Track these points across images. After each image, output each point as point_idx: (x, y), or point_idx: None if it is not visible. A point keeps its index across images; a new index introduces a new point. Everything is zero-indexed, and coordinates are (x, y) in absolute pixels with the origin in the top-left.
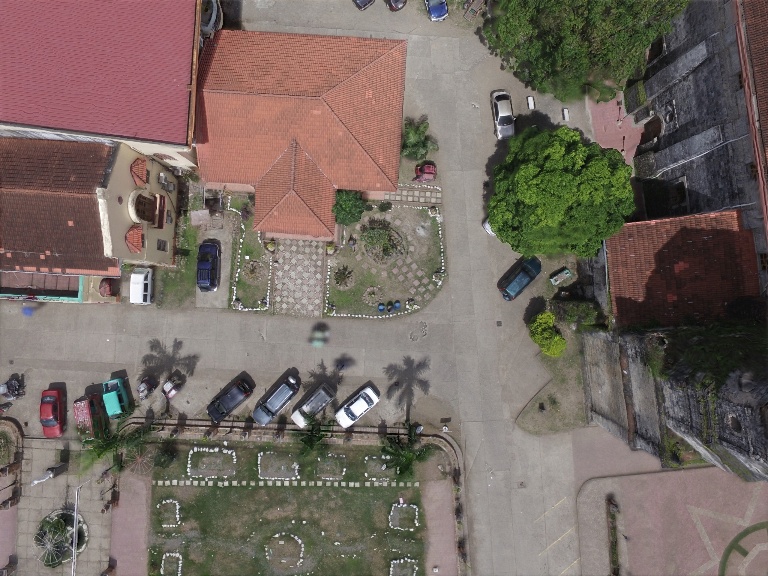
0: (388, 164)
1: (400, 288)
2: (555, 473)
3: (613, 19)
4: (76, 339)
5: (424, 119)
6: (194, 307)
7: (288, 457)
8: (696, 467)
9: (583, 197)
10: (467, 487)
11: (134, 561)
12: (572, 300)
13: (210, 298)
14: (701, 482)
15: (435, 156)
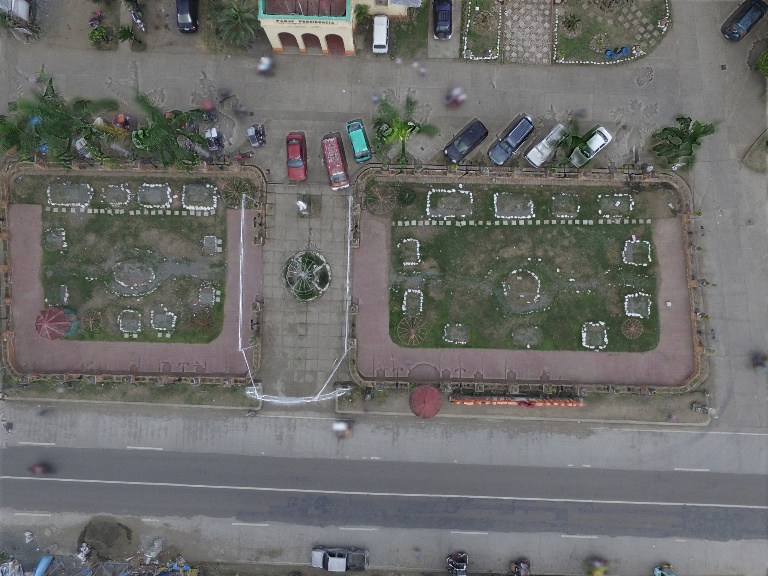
0: None
1: (626, 35)
2: None
3: None
4: (313, 90)
5: None
6: (426, 58)
7: (523, 196)
8: None
9: None
10: (697, 225)
11: (376, 299)
12: None
13: (442, 49)
14: None
15: None
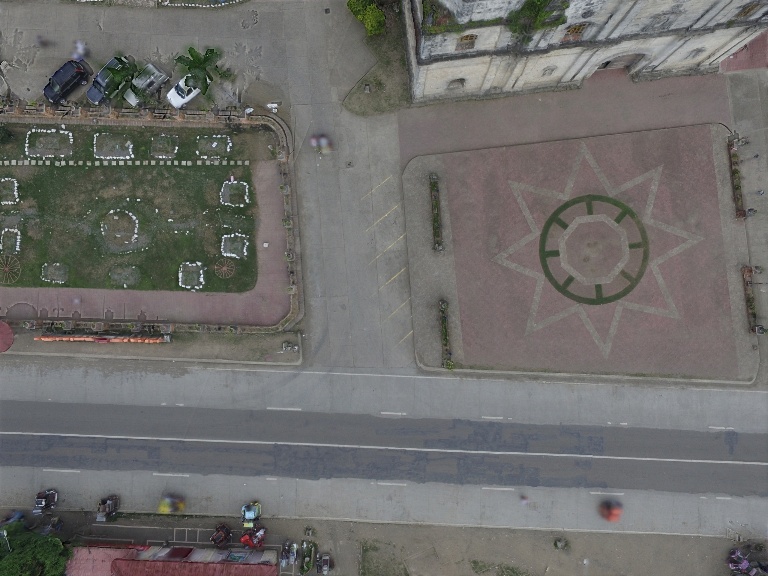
0: None
1: None
2: (381, 152)
3: None
4: None
5: None
6: None
7: (122, 137)
8: (517, 144)
9: None
10: (297, 167)
11: None
12: None
13: None
14: (522, 158)
15: None
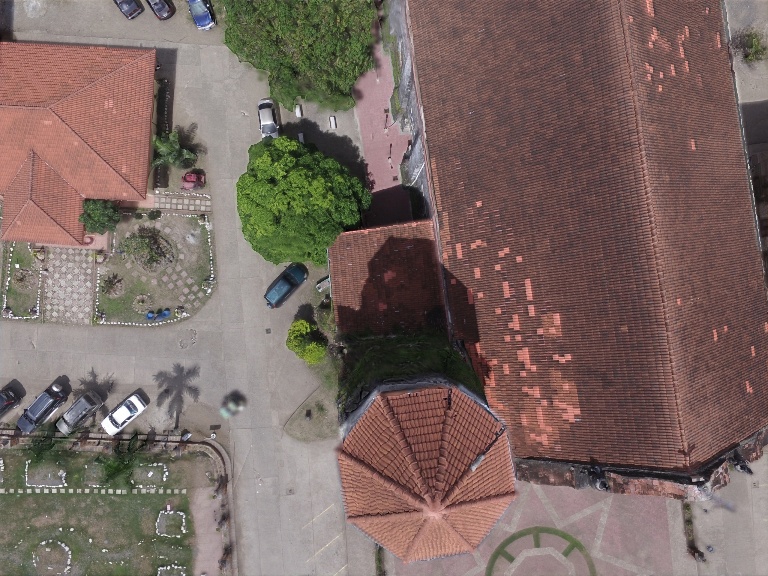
0: (133, 173)
1: (170, 296)
2: (323, 480)
3: (301, 30)
4: None
5: (194, 127)
6: None
7: (55, 465)
8: None
9: (281, 207)
10: (235, 494)
11: None
12: (327, 308)
13: None
14: None
15: (205, 164)
